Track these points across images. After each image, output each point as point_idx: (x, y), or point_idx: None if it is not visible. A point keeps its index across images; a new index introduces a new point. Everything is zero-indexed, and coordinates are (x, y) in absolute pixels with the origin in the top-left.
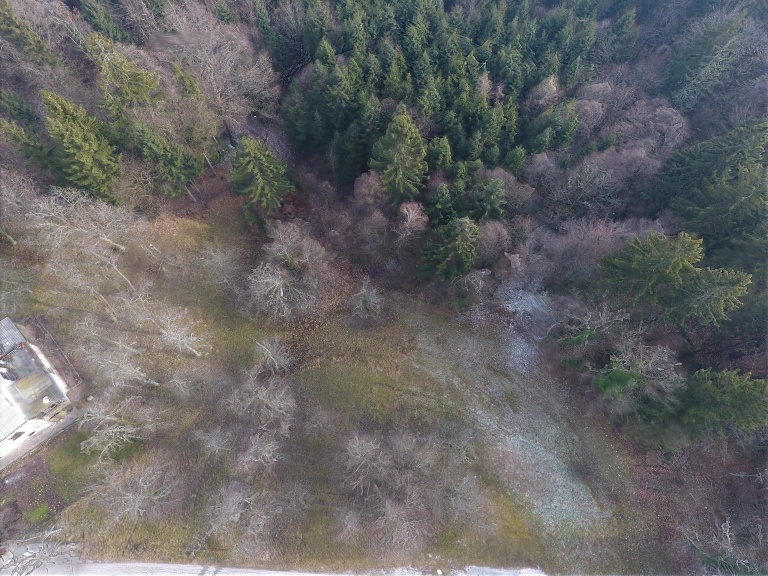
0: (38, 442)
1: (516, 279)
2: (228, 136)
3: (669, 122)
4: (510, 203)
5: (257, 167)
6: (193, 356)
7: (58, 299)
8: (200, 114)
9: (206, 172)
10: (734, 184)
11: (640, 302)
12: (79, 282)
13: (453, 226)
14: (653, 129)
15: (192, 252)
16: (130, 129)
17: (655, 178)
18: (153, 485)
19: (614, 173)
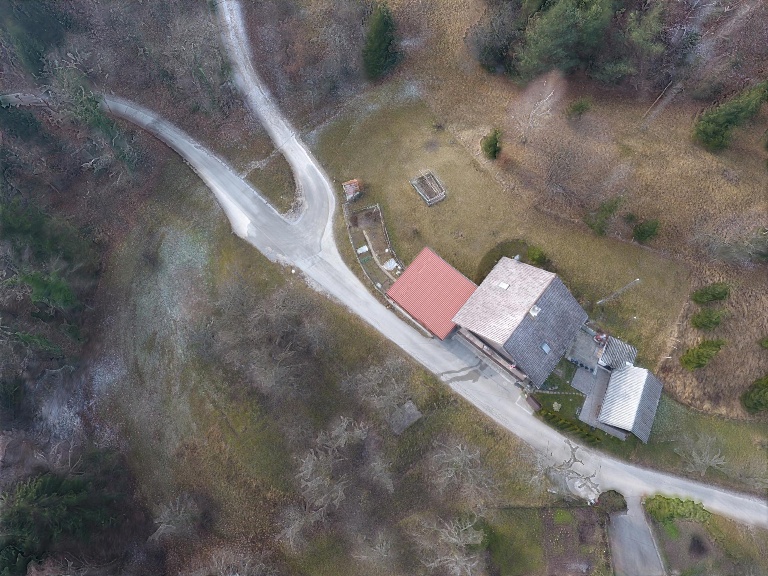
0: None
1: None
2: None
3: None
4: None
5: None
6: None
7: None
8: None
9: None
10: None
11: None
12: None
13: (7, 523)
14: None
15: None
16: None
17: None
18: None
19: None
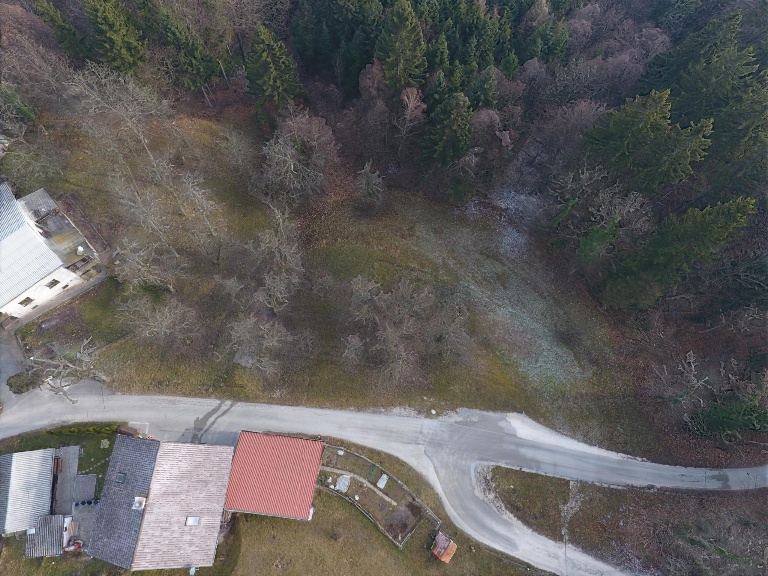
0: (71, 296)
1: (509, 187)
2: (240, 58)
3: None
4: (502, 98)
5: (270, 58)
6: (210, 235)
7: (86, 181)
8: (218, 12)
9: (221, 82)
10: (706, 69)
11: (618, 171)
12: (110, 148)
13: (449, 103)
14: (638, 45)
15: (208, 148)
16: (155, 20)
17: (638, 84)
18: (176, 325)
19: (599, 74)
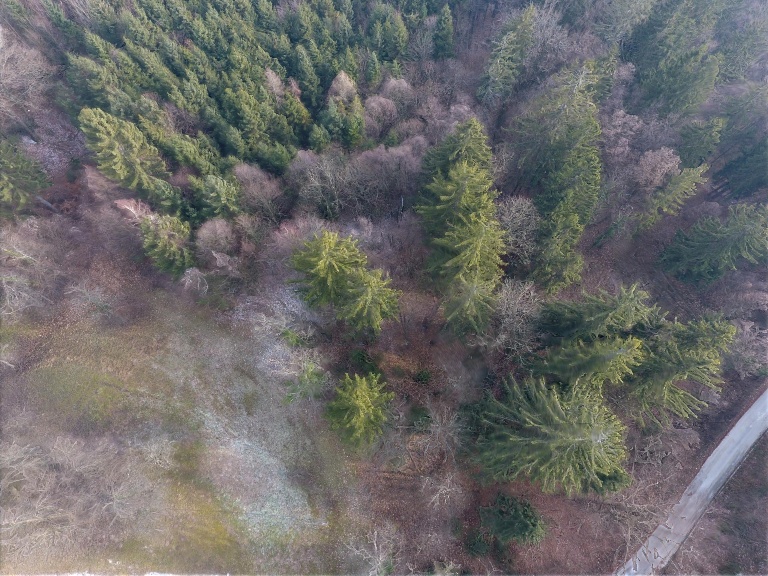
0: None
1: None
2: (32, 131)
3: (461, 120)
4: (250, 201)
5: None
6: None
7: None
8: None
9: None
10: None
11: None
12: None
13: None
14: (438, 127)
15: None
16: None
17: (421, 177)
18: None
19: (366, 171)
